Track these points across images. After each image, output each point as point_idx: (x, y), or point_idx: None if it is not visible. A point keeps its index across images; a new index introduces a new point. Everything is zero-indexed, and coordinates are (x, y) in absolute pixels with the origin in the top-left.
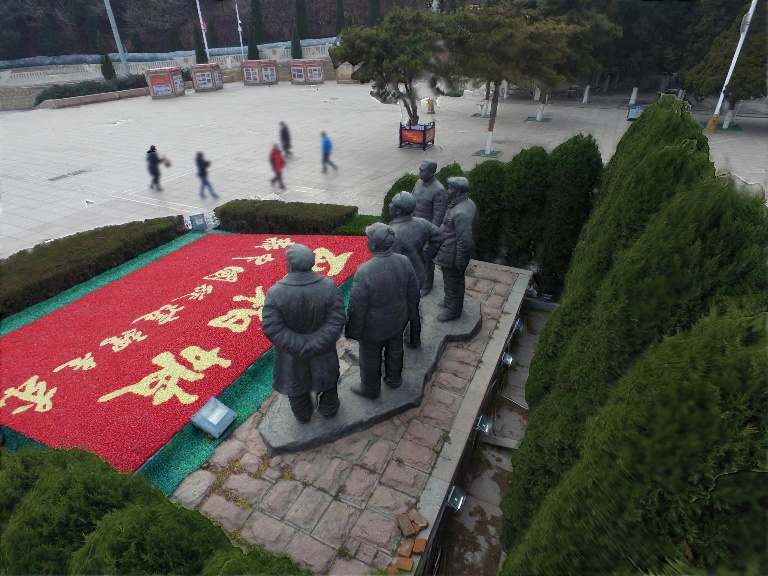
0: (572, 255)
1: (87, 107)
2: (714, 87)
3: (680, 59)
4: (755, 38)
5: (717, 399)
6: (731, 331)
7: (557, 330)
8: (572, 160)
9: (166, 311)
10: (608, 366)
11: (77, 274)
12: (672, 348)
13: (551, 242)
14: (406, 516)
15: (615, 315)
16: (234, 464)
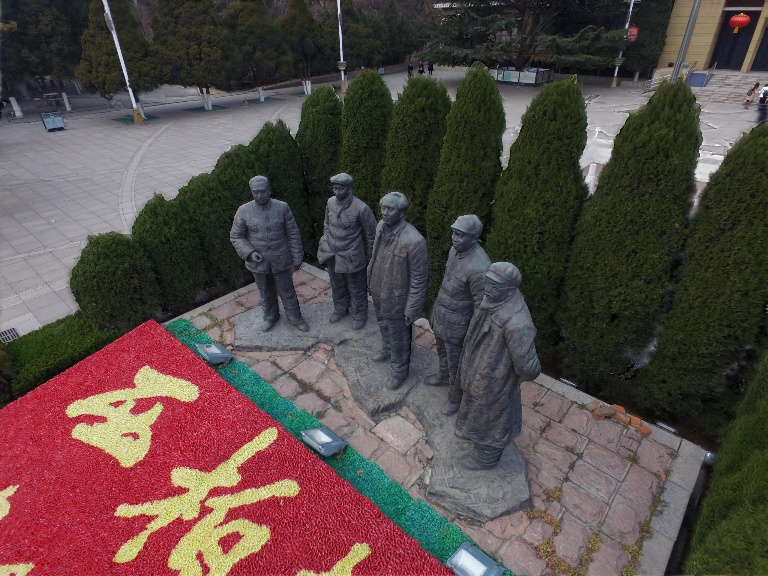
0: (315, 231)
1: None
2: (119, 83)
3: (44, 61)
4: (122, 36)
5: None
6: None
7: (539, 230)
8: (283, 147)
9: None
10: (673, 195)
11: None
12: (767, 143)
13: (300, 228)
14: (598, 408)
15: (676, 164)
16: (542, 551)
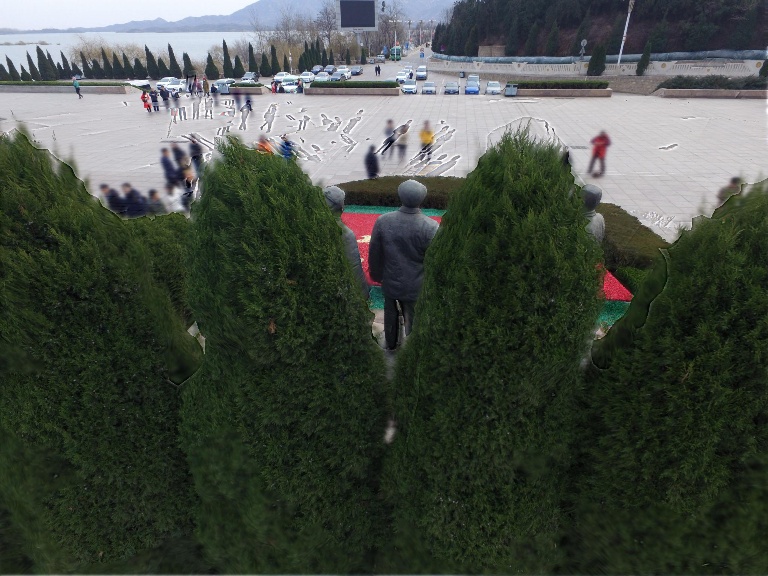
0: None
1: (691, 100)
2: None
3: None
4: None
5: None
6: None
7: None
8: None
9: None
10: None
11: (438, 202)
12: None
13: None
14: None
15: None
16: None
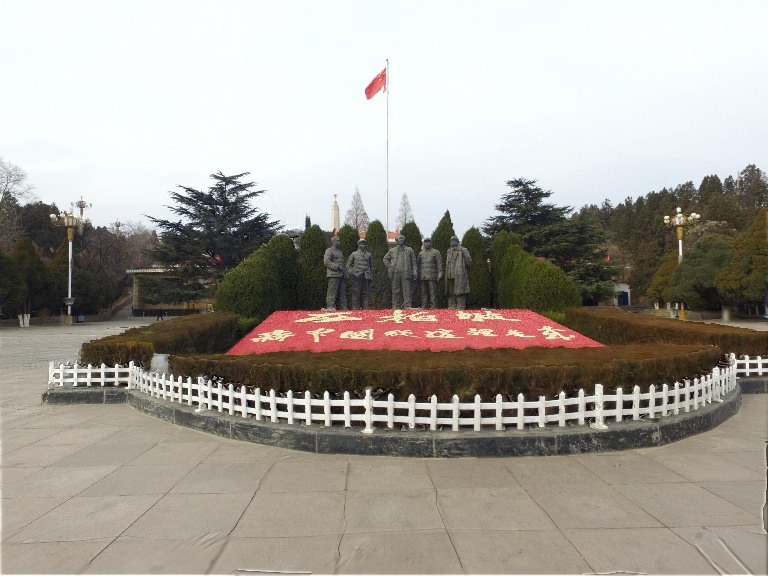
0: None
1: None
2: None
3: None
4: None
5: (480, 233)
6: (474, 228)
7: None
8: None
9: (436, 334)
10: None
11: None
12: (472, 233)
13: None
14: None
15: None
16: None
